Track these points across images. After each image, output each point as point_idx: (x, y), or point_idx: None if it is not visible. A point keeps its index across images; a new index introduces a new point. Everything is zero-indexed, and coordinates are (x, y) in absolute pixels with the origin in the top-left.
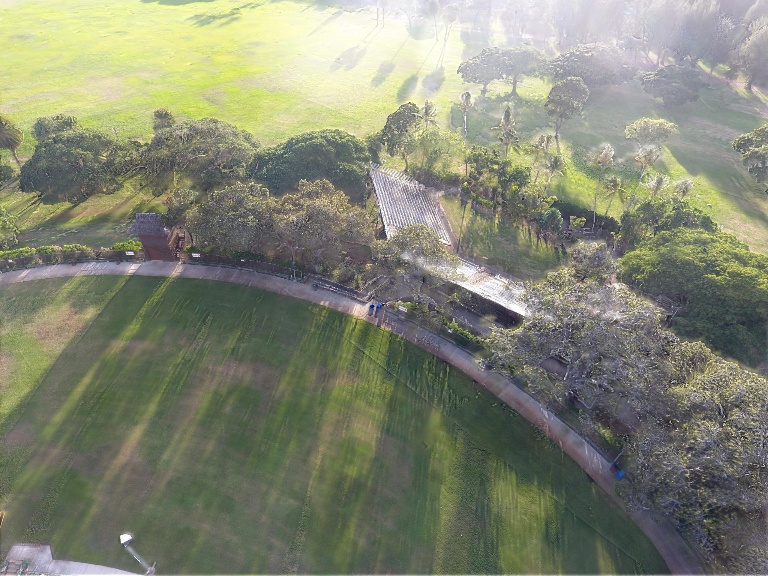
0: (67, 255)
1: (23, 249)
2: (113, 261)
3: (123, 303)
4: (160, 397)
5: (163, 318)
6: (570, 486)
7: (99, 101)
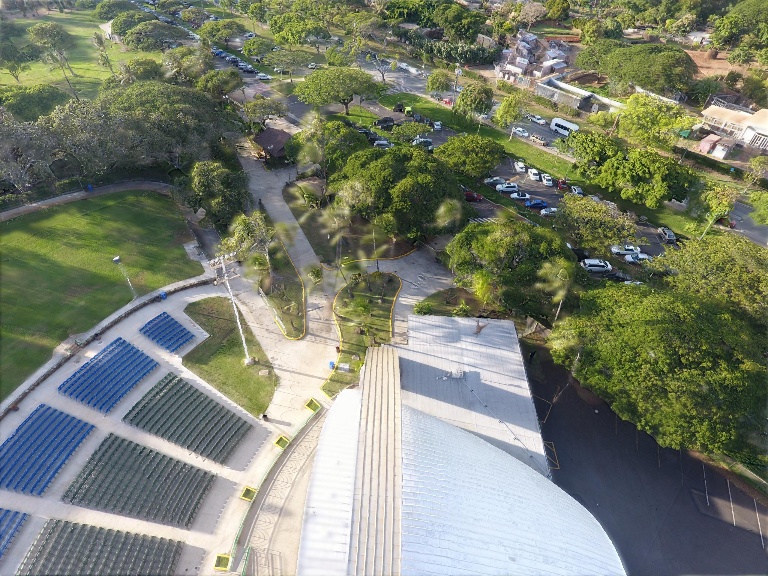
0: None
1: None
2: None
3: None
4: None
5: None
6: (82, 207)
7: None
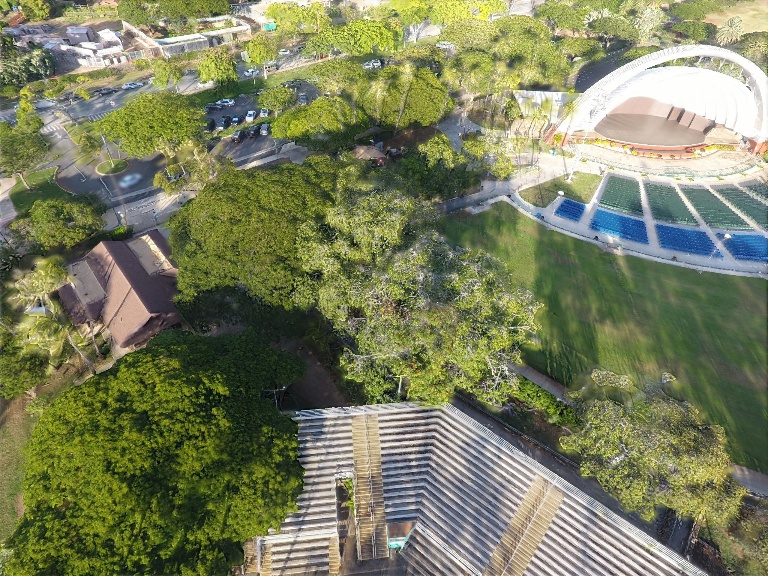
0: None
1: None
2: None
3: None
4: None
5: None
6: None
7: None
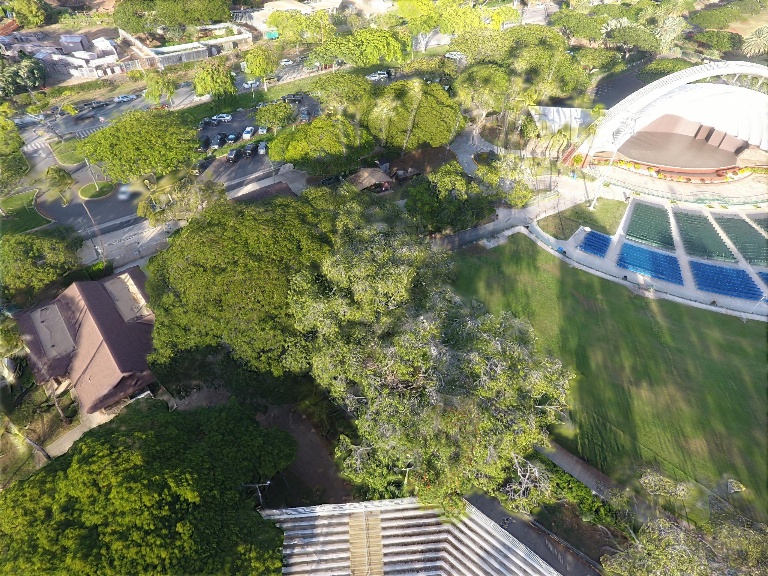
0: None
1: None
2: None
3: None
4: None
5: None
6: None
7: None
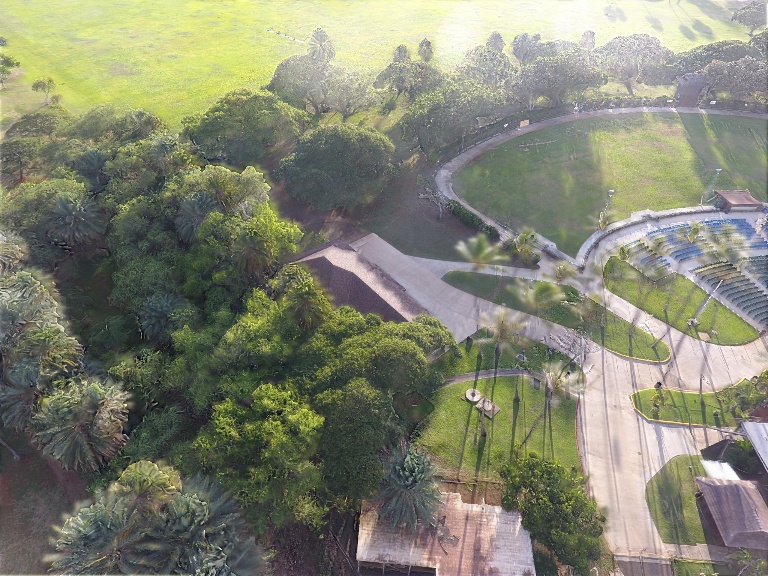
0: (631, 102)
1: None
2: (656, 106)
3: (691, 123)
4: (766, 158)
5: (724, 130)
6: None
7: (472, 38)
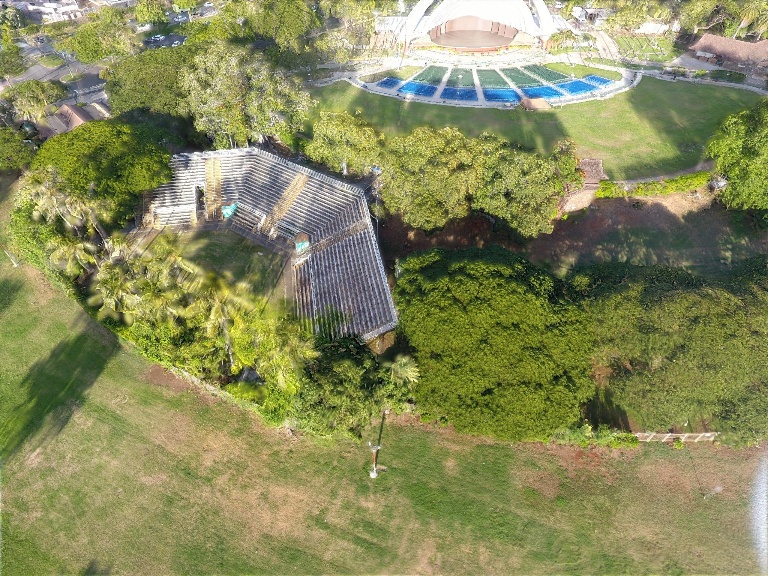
0: None
1: (691, 181)
2: None
3: None
4: None
5: None
6: (283, 114)
7: None
